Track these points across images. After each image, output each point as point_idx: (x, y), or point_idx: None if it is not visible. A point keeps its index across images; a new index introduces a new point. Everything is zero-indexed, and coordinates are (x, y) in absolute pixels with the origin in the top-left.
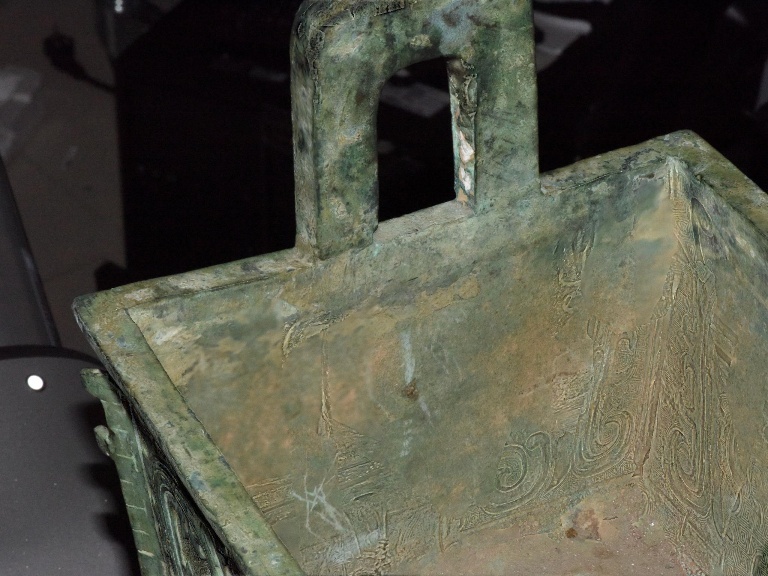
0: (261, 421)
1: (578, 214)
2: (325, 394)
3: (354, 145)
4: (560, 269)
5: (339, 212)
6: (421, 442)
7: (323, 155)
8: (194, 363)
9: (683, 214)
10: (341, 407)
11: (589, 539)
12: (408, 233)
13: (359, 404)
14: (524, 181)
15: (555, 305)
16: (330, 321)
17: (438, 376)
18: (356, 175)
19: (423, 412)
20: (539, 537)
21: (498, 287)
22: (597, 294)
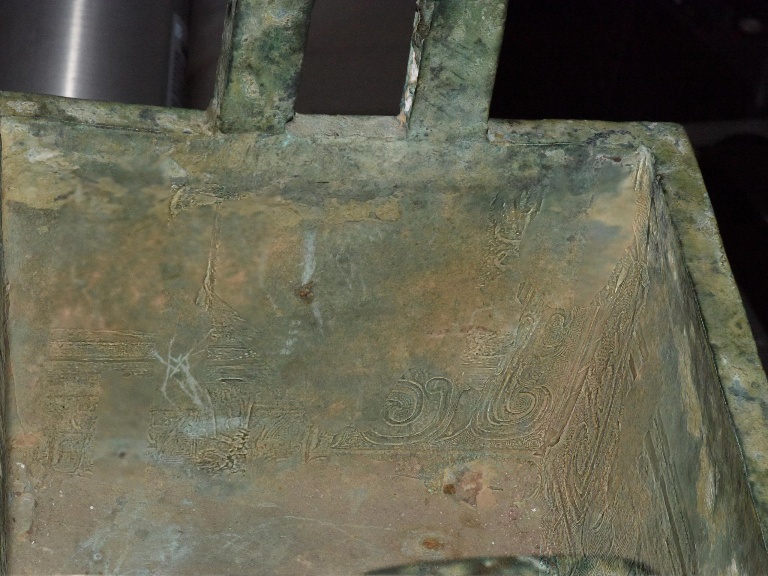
0: (135, 271)
1: (525, 173)
2: (211, 266)
3: (281, 28)
4: (497, 222)
5: (250, 90)
6: (307, 346)
7: (244, 28)
8: (69, 192)
9: (644, 209)
10: (226, 284)
11: (465, 501)
12: (327, 134)
13: (247, 288)
14: (469, 121)
15: (486, 257)
16: (225, 196)
17: (339, 287)
18: (277, 59)
19: (315, 318)
20: (414, 481)
21: (422, 219)
22: (537, 260)
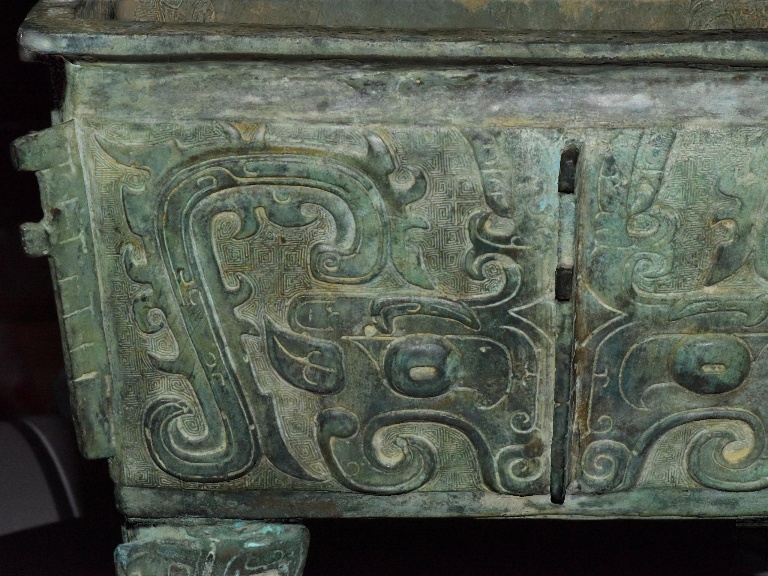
0: None
1: None
2: None
3: None
4: None
5: None
6: None
7: None
8: None
9: None
10: None
11: None
12: None
13: None
14: None
15: None
16: None
17: None
18: None
19: None
20: None
21: None
22: None
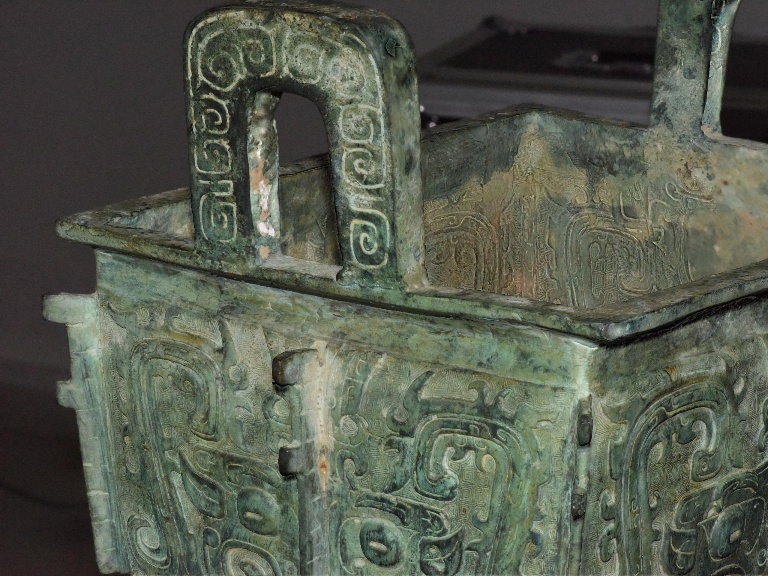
0: None
1: None
2: None
3: None
4: None
5: None
6: None
7: None
8: None
9: None
10: None
11: None
12: None
13: None
14: None
15: None
16: None
17: None
18: None
19: None
20: None
21: None
22: None
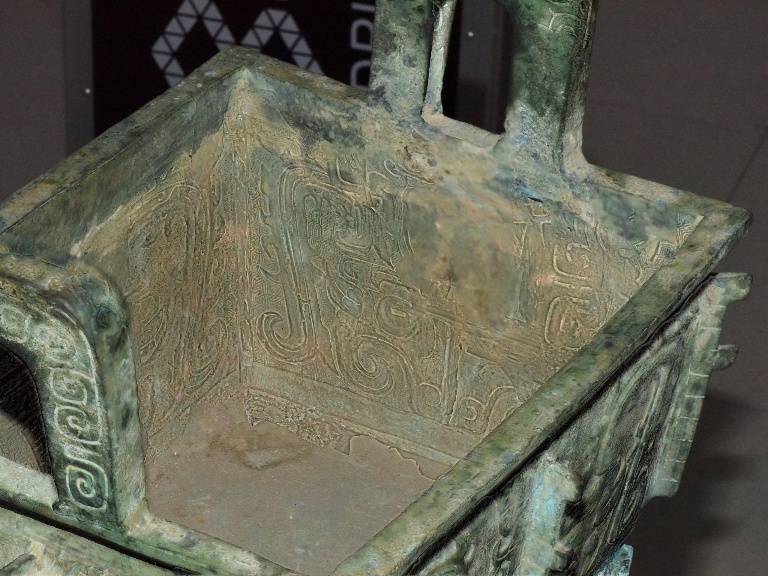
0: None
1: None
2: None
3: None
4: None
5: None
6: None
7: None
8: None
9: None
10: None
11: None
12: None
13: None
14: None
15: None
16: None
17: None
18: None
19: None
20: None
21: None
22: None
